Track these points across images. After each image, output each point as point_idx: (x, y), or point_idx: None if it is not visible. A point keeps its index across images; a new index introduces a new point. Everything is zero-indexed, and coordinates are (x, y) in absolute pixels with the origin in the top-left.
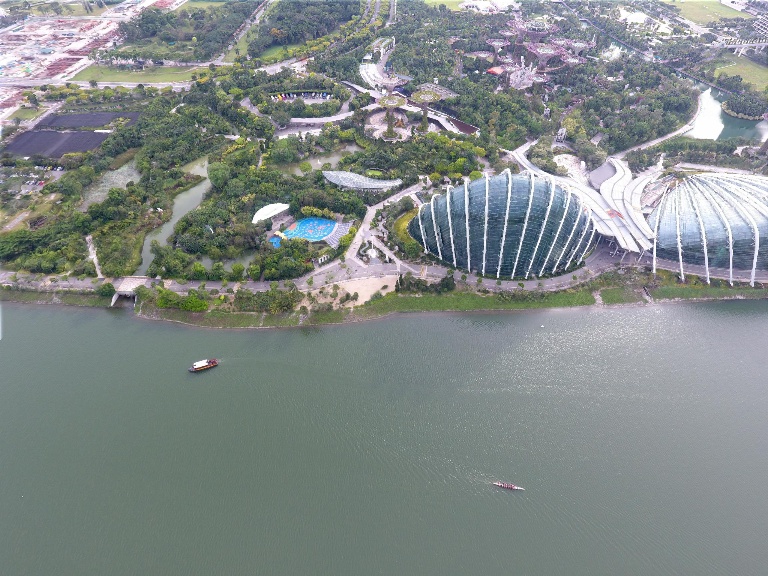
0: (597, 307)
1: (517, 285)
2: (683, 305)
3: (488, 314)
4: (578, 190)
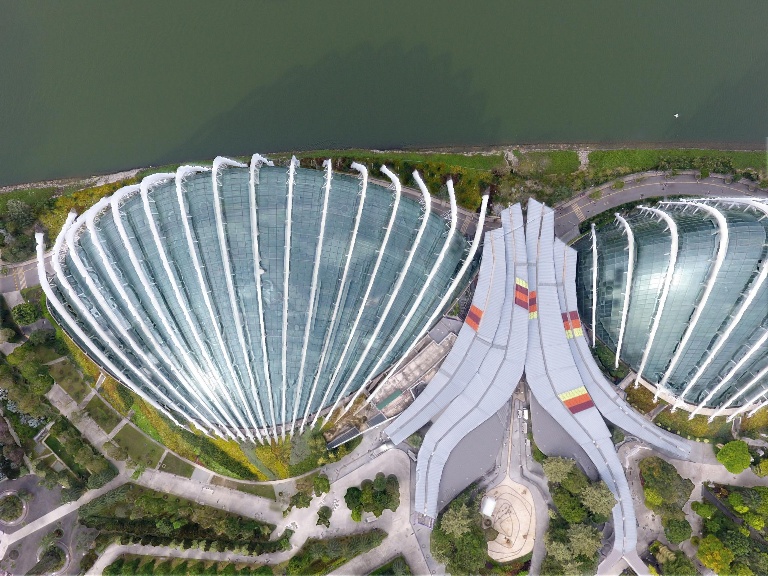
0: (589, 147)
1: (698, 187)
2: (466, 144)
3: (744, 143)
4: (558, 386)
